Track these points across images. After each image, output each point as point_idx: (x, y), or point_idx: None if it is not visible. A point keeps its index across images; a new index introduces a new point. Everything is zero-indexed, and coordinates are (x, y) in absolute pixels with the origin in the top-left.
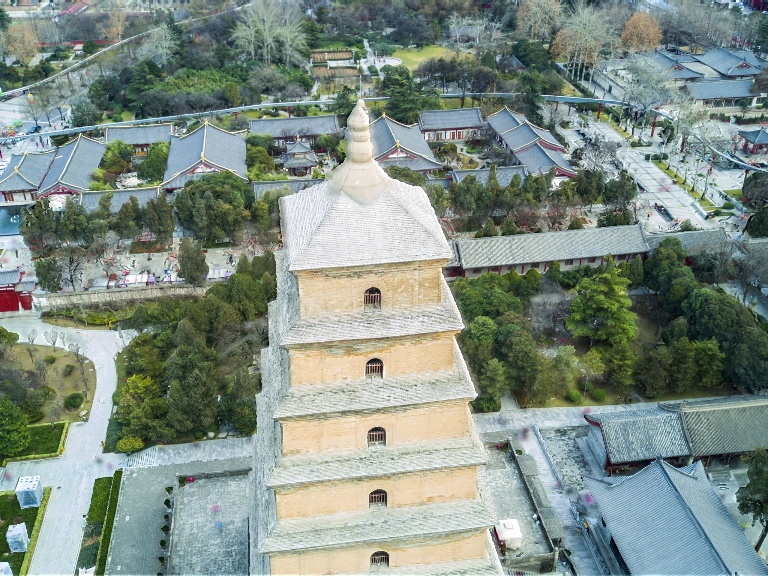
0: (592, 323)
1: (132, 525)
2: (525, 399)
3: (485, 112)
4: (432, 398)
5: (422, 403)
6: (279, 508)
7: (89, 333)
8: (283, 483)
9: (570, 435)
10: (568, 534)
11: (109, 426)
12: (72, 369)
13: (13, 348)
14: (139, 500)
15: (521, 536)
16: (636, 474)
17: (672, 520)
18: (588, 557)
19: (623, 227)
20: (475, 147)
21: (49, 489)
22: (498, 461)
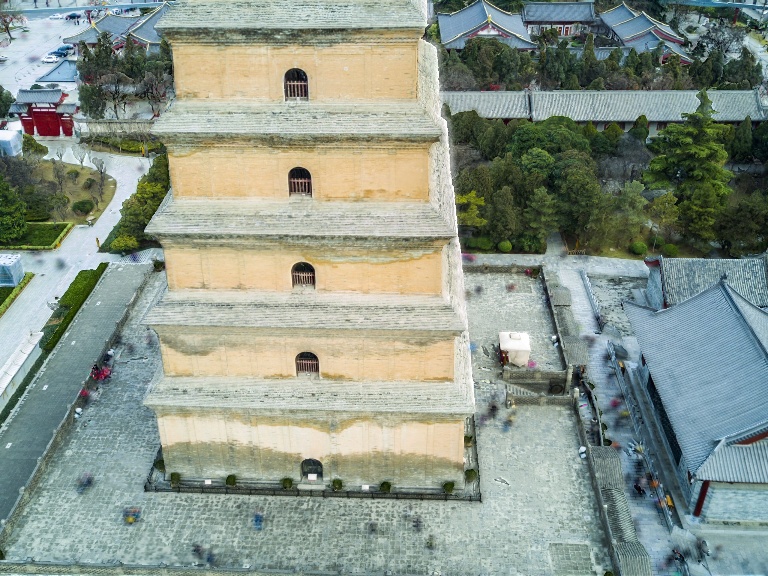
0: (675, 175)
1: (101, 309)
2: (576, 242)
3: (599, 8)
4: (365, 23)
5: (351, 29)
6: (174, 178)
7: (121, 158)
8: (171, 130)
9: (625, 285)
10: (597, 371)
11: (112, 231)
12: (93, 183)
13: (43, 163)
14: (116, 289)
15: (528, 349)
16: (690, 298)
17: (726, 343)
18: (616, 396)
19: (734, 92)
20: (582, 42)
21: (31, 274)
22: (524, 286)
